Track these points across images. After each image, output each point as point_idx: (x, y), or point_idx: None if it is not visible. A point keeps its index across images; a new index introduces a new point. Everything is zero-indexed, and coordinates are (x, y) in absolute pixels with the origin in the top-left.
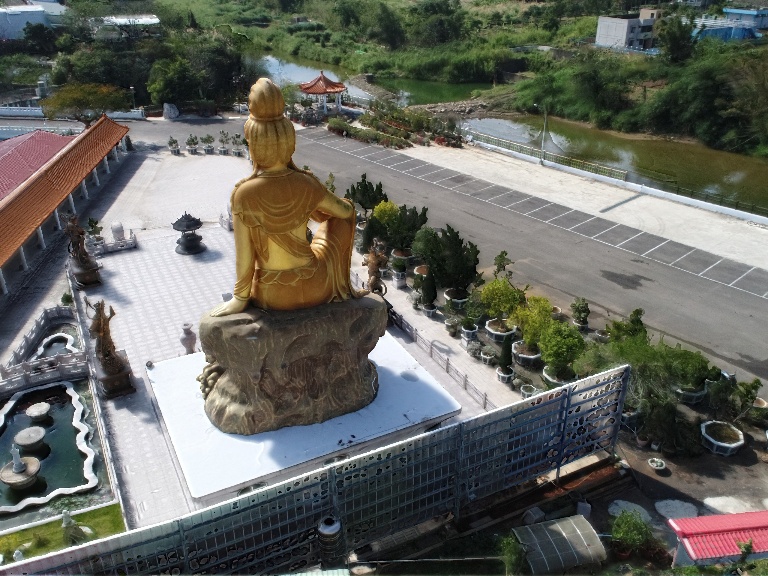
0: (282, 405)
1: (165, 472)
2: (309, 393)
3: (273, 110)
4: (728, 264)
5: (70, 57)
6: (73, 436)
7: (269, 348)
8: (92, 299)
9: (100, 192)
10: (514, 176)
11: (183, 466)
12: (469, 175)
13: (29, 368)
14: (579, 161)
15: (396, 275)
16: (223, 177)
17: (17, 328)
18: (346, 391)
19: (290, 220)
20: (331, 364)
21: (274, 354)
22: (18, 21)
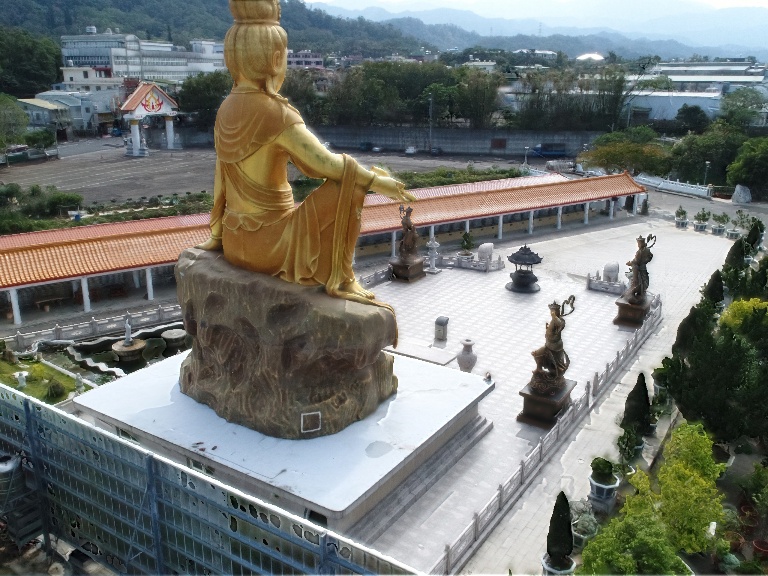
0: (210, 377)
1: None
2: (233, 378)
3: (237, 9)
4: None
5: (699, 137)
6: None
7: (192, 293)
8: (384, 288)
9: (550, 232)
10: None
11: (118, 380)
12: None
13: None
14: None
15: (654, 388)
16: (686, 253)
17: None
18: (266, 402)
19: (235, 147)
20: (259, 356)
21: (197, 304)
22: (678, 102)
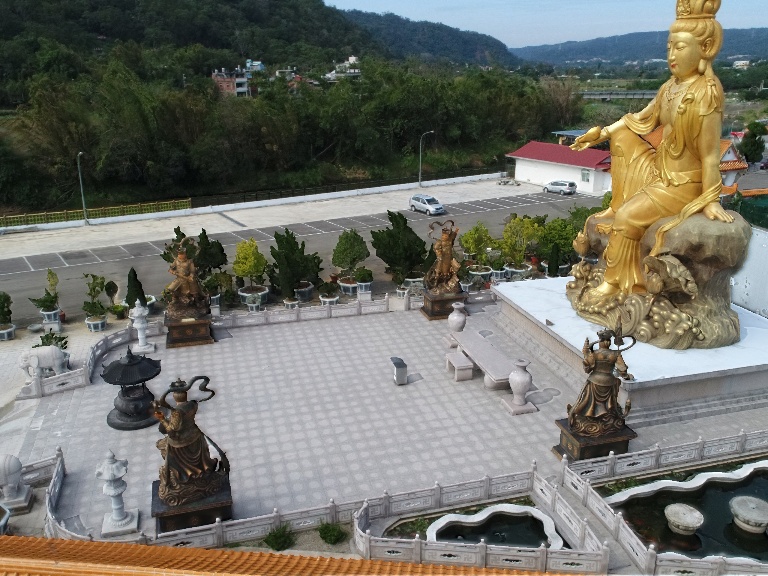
0: None
1: (759, 415)
2: None
3: None
4: (378, 216)
5: None
6: (705, 500)
7: None
8: None
9: None
10: (106, 237)
11: None
12: (68, 251)
13: None
14: (135, 206)
15: (369, 287)
16: None
17: None
18: None
19: None
20: None
21: None
22: None
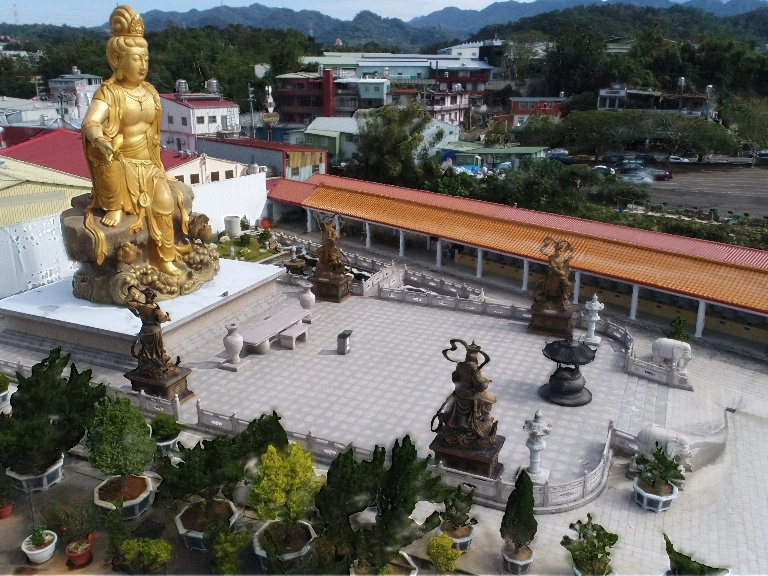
0: None
1: None
2: None
3: None
4: None
5: None
6: None
7: None
8: (498, 322)
9: None
10: None
11: None
12: None
13: (398, 277)
14: None
15: None
16: None
17: (487, 294)
18: None
19: None
20: None
21: None
22: None
